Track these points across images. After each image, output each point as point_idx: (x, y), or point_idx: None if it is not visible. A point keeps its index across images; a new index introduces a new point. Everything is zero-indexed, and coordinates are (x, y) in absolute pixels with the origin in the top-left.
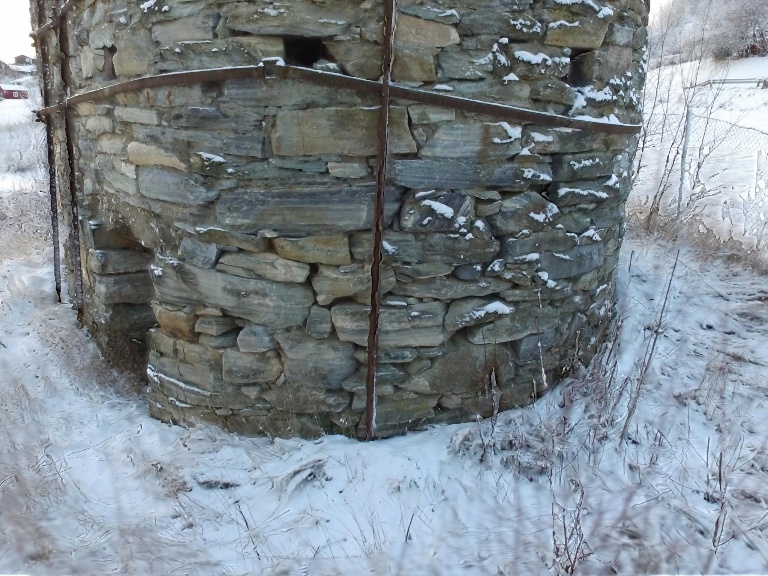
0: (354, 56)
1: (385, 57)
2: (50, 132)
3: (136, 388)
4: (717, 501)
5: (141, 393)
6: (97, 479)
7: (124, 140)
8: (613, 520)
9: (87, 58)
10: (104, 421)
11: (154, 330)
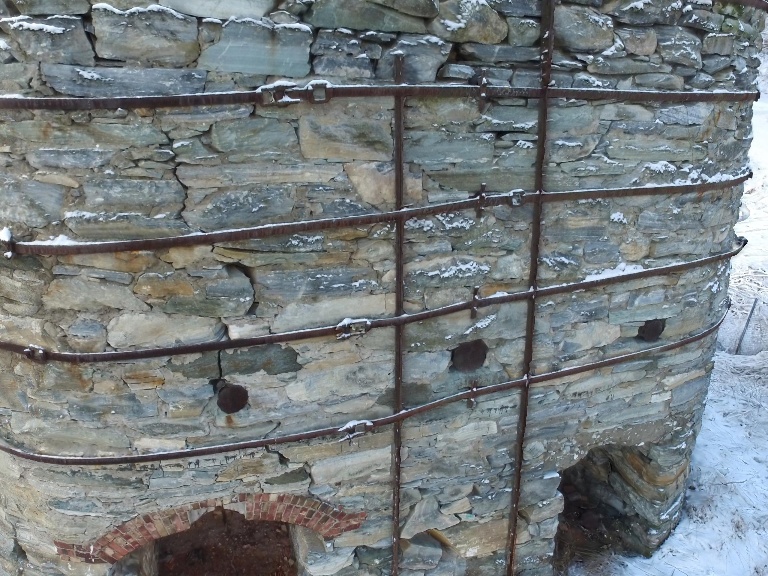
0: None
1: None
2: None
3: (588, 569)
4: (714, 390)
5: (603, 562)
6: (731, 573)
7: (659, 379)
8: (717, 415)
9: (595, 331)
10: (662, 575)
11: (664, 489)
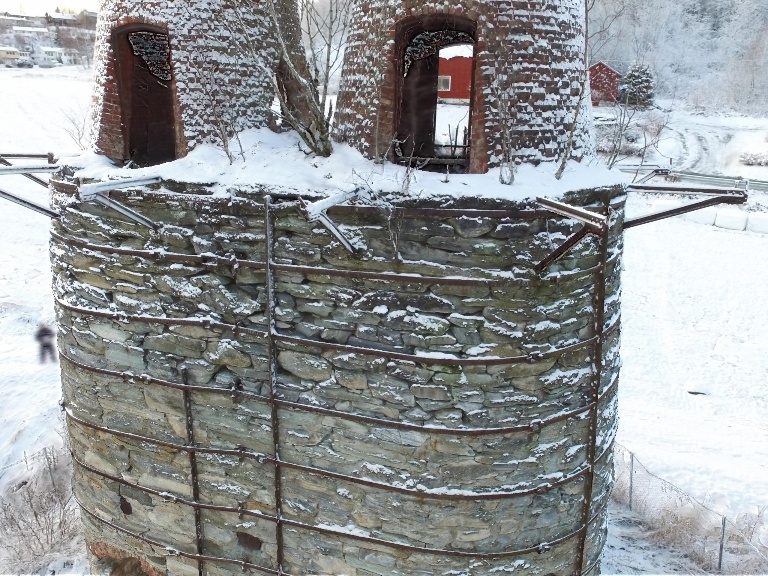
0: (565, 573)
1: (580, 571)
2: (200, 569)
3: None
4: None
5: None
6: None
7: None
8: None
9: (334, 564)
10: None
11: None
